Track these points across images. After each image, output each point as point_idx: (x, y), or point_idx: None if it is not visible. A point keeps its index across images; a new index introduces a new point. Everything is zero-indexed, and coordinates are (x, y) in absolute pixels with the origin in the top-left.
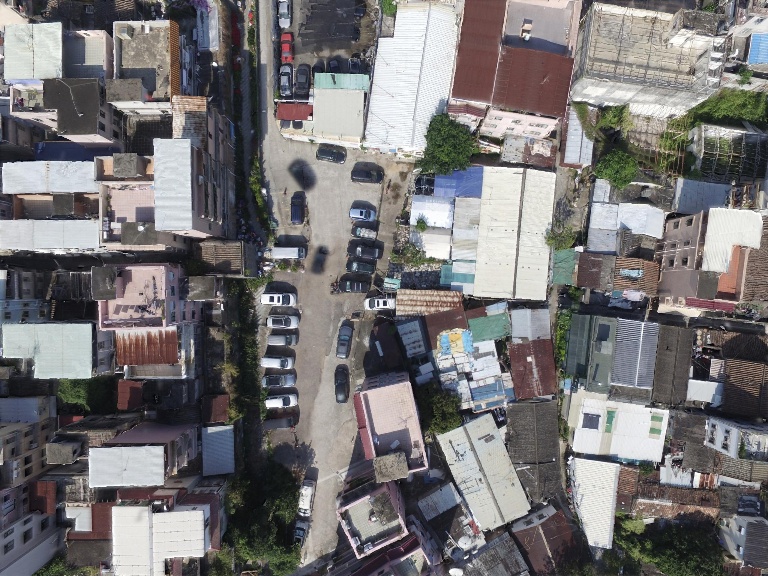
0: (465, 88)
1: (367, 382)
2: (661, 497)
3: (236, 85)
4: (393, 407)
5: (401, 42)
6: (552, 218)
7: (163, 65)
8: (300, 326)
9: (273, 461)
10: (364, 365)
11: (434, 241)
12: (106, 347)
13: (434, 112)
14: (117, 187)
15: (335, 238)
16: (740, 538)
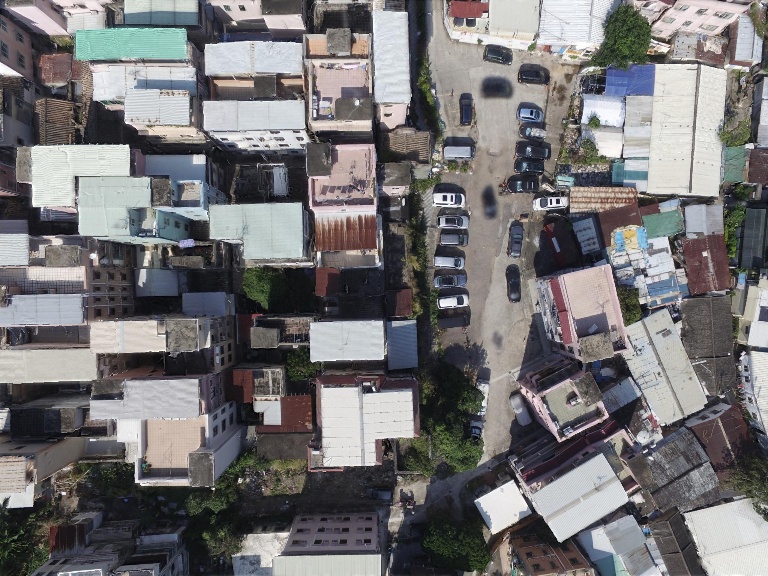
0: None
1: None
2: None
3: None
4: (590, 292)
5: None
6: None
7: None
8: (469, 227)
9: (444, 362)
10: (535, 265)
11: (607, 139)
12: (305, 233)
13: (609, 8)
14: (324, 66)
15: (502, 140)
16: None
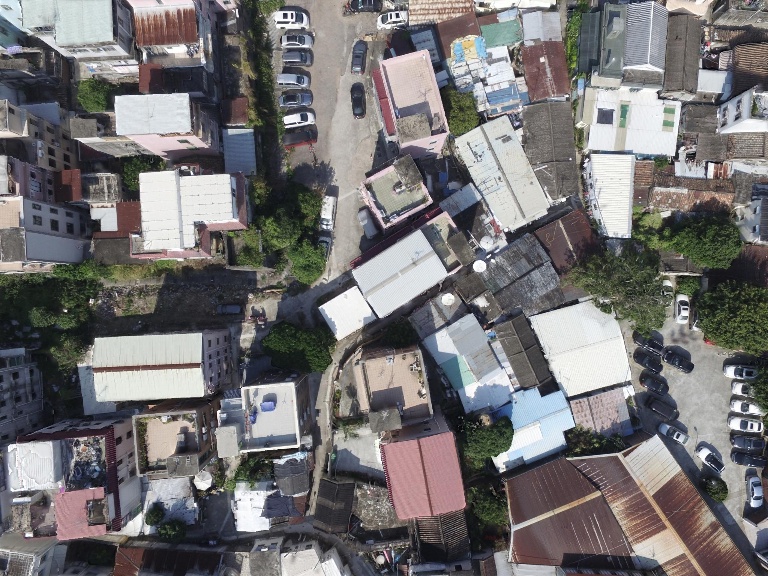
0: None
1: None
2: (677, 185)
3: None
4: (412, 81)
5: None
6: None
7: None
8: (314, 48)
9: (293, 182)
10: None
11: None
12: (125, 29)
13: None
14: None
15: None
16: (755, 218)
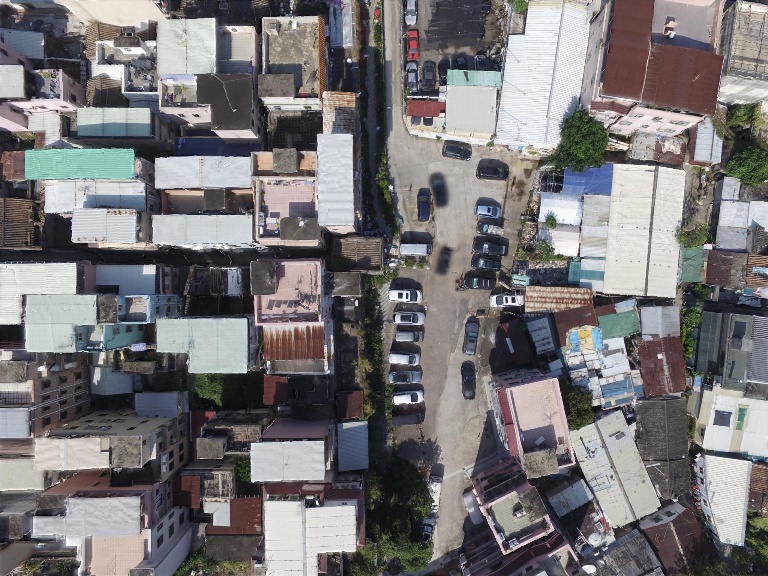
0: (615, 85)
1: (501, 378)
2: None
3: (362, 82)
4: (538, 403)
5: (533, 39)
6: (682, 216)
7: (309, 61)
8: (425, 323)
9: (398, 457)
10: (490, 362)
11: (563, 238)
12: (253, 342)
13: (566, 109)
14: (272, 182)
15: (460, 235)
16: None
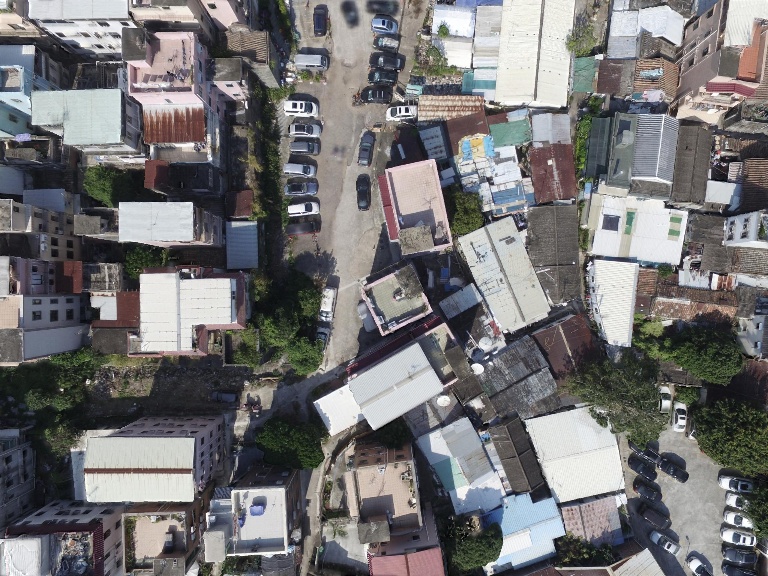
0: None
1: None
2: (680, 296)
3: None
4: (417, 188)
5: None
6: (573, 25)
7: None
8: (322, 137)
9: (295, 270)
10: None
11: (456, 48)
12: (133, 125)
13: None
14: None
15: (357, 51)
16: (758, 334)
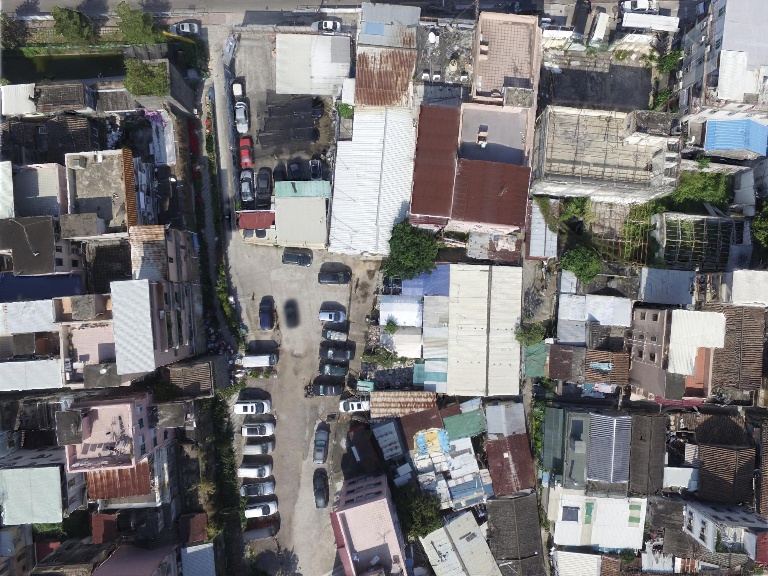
0: (424, 203)
1: (345, 491)
2: None
3: (197, 193)
4: (371, 523)
5: (360, 145)
6: (521, 312)
7: (119, 193)
8: (276, 432)
9: (256, 569)
10: (342, 468)
11: (405, 341)
12: (77, 483)
13: (397, 215)
14: (77, 326)
15: (306, 341)
16: None
